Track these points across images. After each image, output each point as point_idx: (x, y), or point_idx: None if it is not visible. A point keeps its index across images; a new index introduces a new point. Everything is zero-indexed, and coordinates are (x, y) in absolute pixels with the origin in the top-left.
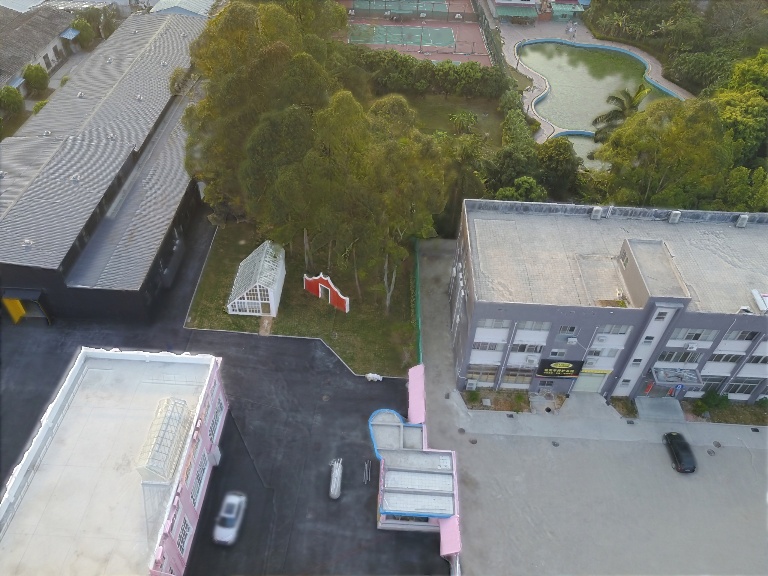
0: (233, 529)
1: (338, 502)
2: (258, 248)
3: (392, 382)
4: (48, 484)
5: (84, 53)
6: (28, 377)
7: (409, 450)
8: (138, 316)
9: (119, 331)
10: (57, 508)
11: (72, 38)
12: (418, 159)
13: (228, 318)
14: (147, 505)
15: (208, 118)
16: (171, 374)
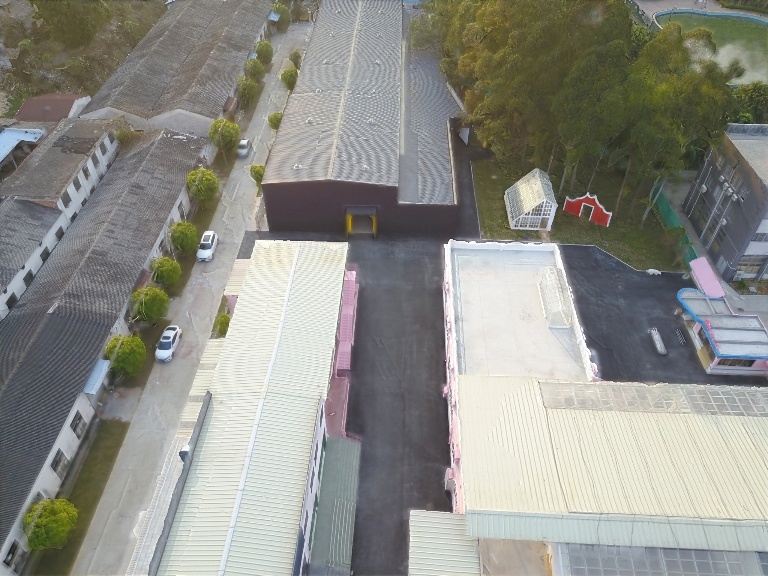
0: (596, 374)
1: (667, 357)
2: (526, 176)
3: (670, 275)
4: (477, 329)
5: (281, 34)
6: (379, 274)
7: (722, 315)
8: (447, 229)
9: (432, 242)
10: (494, 343)
11: (277, 20)
12: (725, 78)
13: (512, 232)
14: (561, 341)
15: (517, 59)
16: (525, 258)
